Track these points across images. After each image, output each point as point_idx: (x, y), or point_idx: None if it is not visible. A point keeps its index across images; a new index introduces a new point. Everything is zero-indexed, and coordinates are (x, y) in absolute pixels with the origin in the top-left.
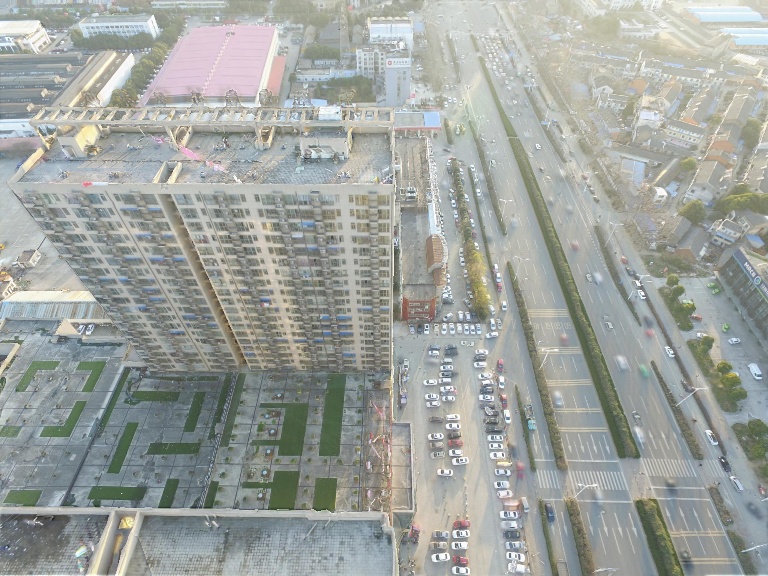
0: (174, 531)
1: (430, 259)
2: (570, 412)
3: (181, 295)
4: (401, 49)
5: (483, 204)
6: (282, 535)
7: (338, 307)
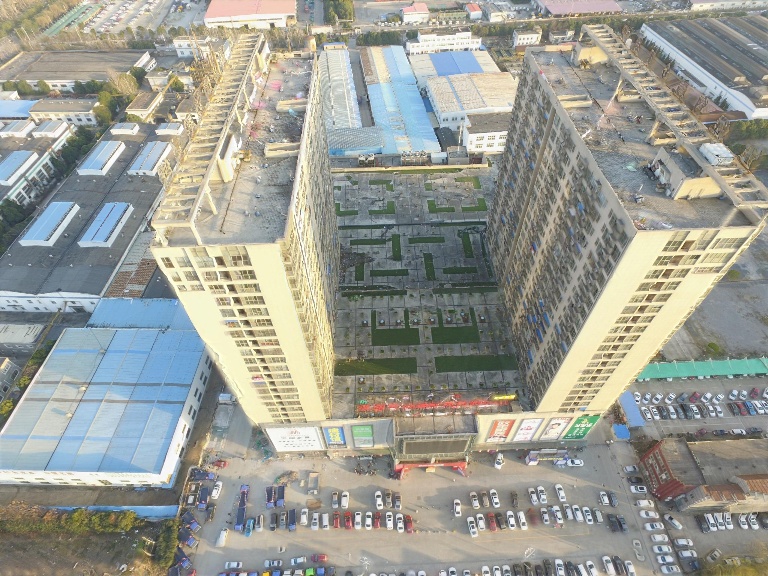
0: (291, 167)
1: (752, 476)
2: None
3: None
4: None
5: None
6: (283, 204)
7: (551, 306)
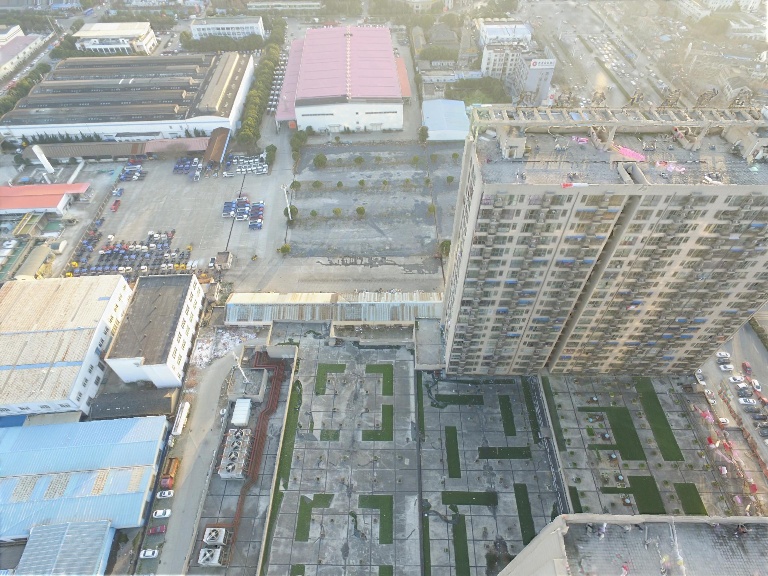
0: None
1: None
2: None
3: (553, 298)
4: (536, 50)
5: None
6: None
7: (702, 310)
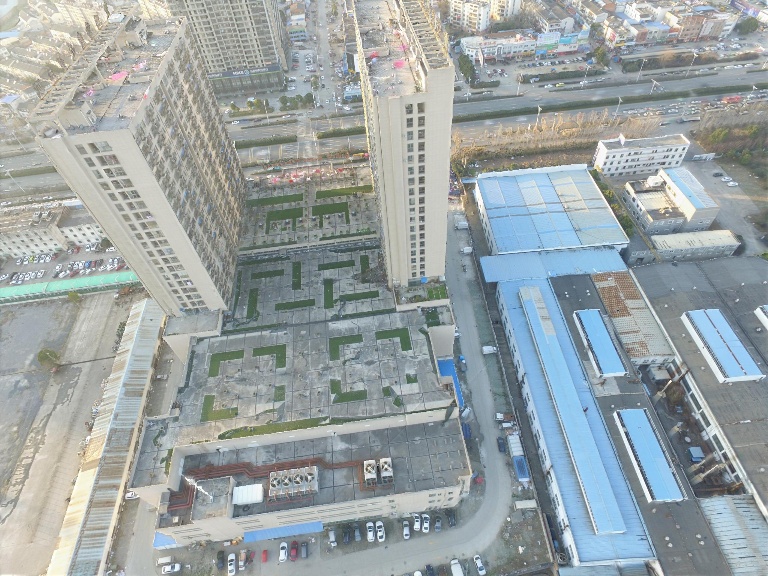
0: None
1: None
2: (270, 156)
3: None
4: None
5: (65, 196)
6: None
7: None
